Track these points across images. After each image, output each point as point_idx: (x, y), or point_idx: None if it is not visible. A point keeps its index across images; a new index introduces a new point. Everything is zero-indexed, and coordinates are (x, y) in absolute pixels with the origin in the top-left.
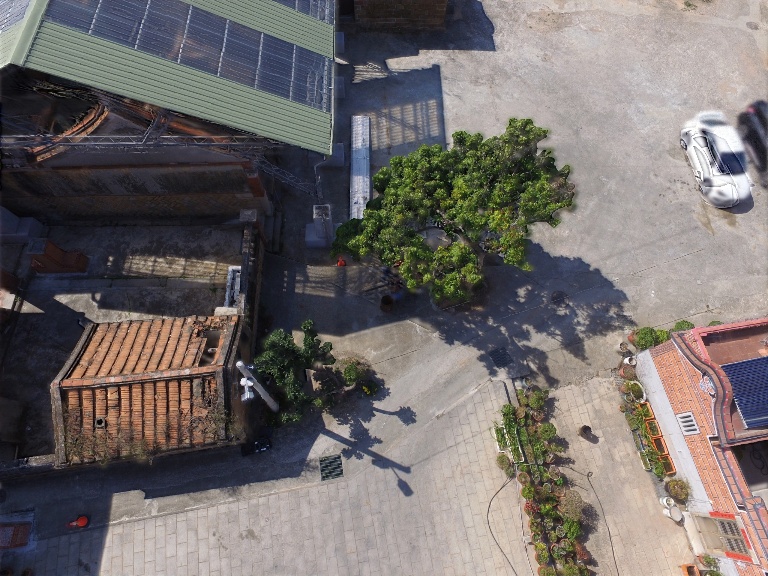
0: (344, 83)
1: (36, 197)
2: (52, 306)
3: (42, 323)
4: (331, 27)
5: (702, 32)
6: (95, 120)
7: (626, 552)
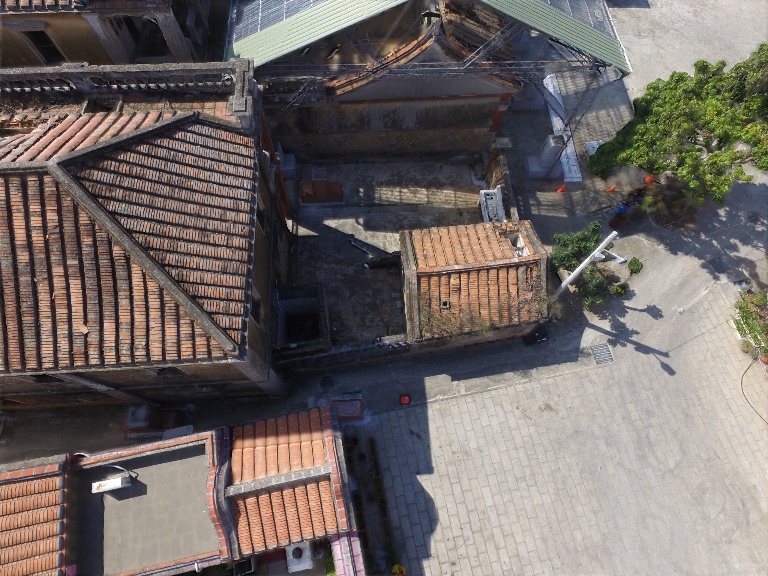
0: None
1: (301, 135)
2: (324, 230)
3: (319, 244)
4: None
5: None
6: (411, 52)
7: None
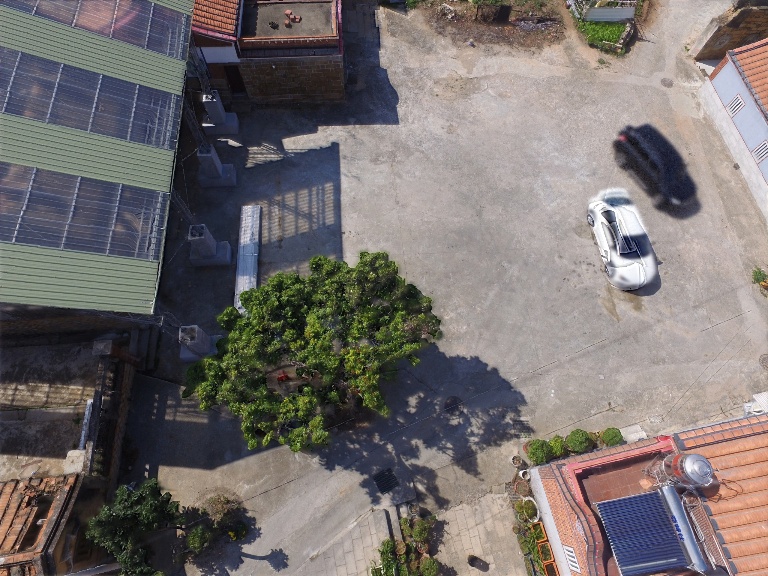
0: (236, 168)
1: None
2: None
3: None
4: (171, 153)
5: (615, 92)
6: None
7: None
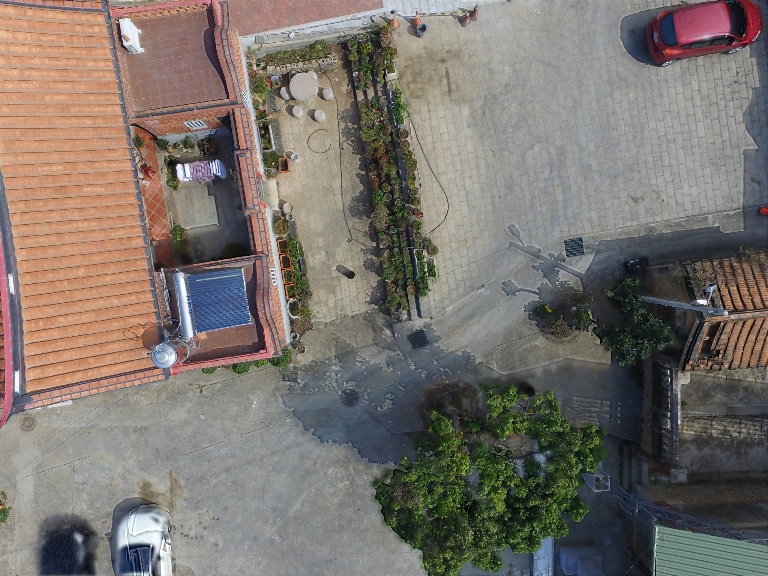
0: None
1: None
2: None
3: None
4: None
5: None
6: None
7: (331, 182)
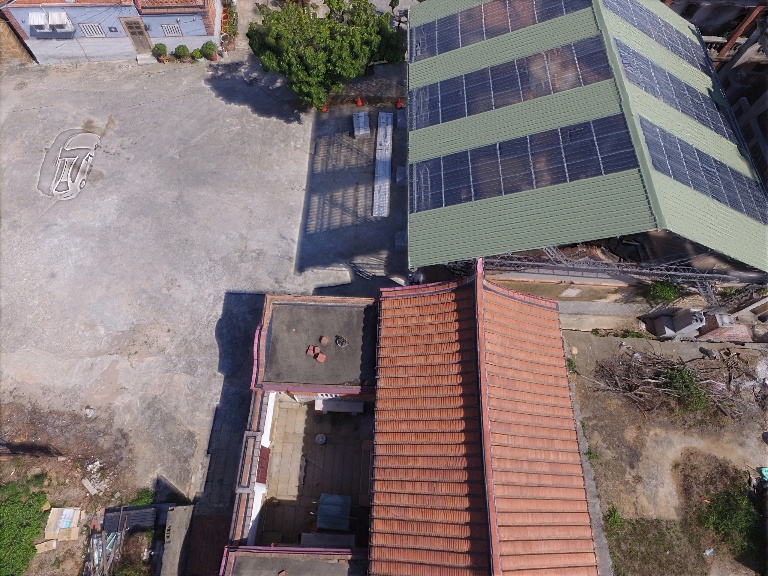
0: (395, 254)
1: None
2: None
3: None
4: None
5: None
6: None
7: None
